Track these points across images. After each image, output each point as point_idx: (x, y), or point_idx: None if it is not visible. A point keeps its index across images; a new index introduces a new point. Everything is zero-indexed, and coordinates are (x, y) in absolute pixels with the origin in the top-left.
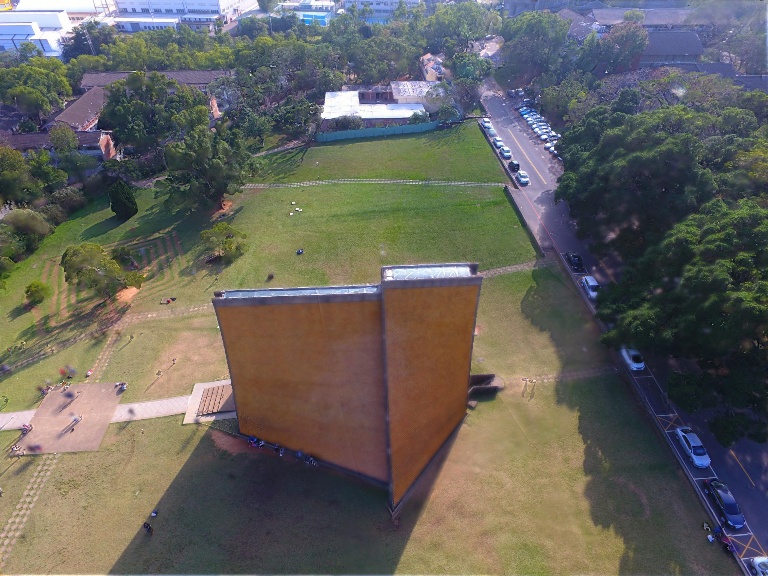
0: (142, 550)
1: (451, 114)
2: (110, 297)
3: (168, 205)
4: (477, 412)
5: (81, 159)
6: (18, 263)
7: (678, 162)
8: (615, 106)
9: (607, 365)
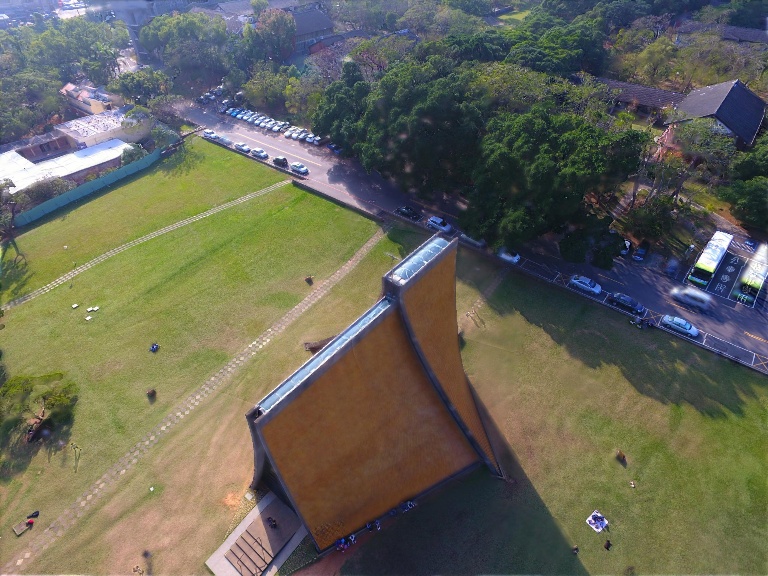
0: None
1: (169, 137)
2: None
3: None
4: (466, 361)
5: None
6: None
7: (444, 103)
8: (347, 78)
9: (500, 270)
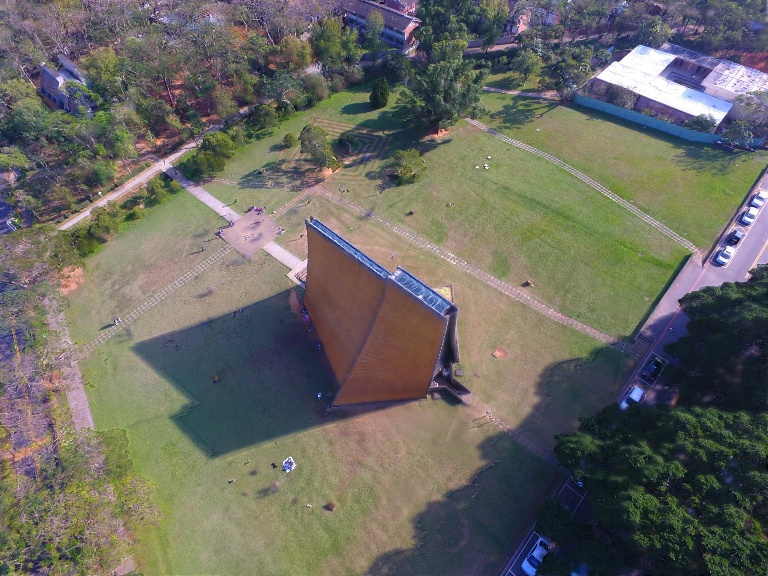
0: (225, 323)
1: (741, 136)
2: (320, 167)
3: (395, 115)
4: (434, 403)
5: (378, 44)
6: (299, 112)
7: None
8: None
9: None
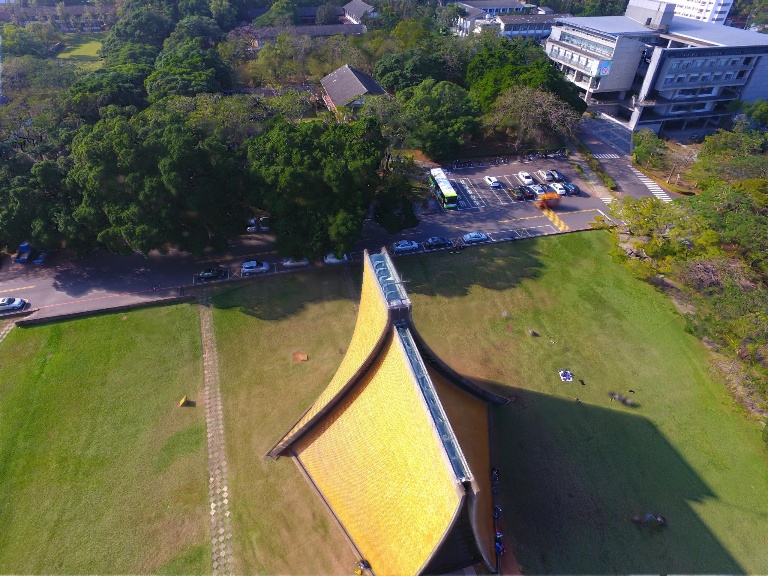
0: None
1: None
2: None
3: None
4: None
5: None
6: None
7: None
8: (7, 166)
9: (342, 273)
